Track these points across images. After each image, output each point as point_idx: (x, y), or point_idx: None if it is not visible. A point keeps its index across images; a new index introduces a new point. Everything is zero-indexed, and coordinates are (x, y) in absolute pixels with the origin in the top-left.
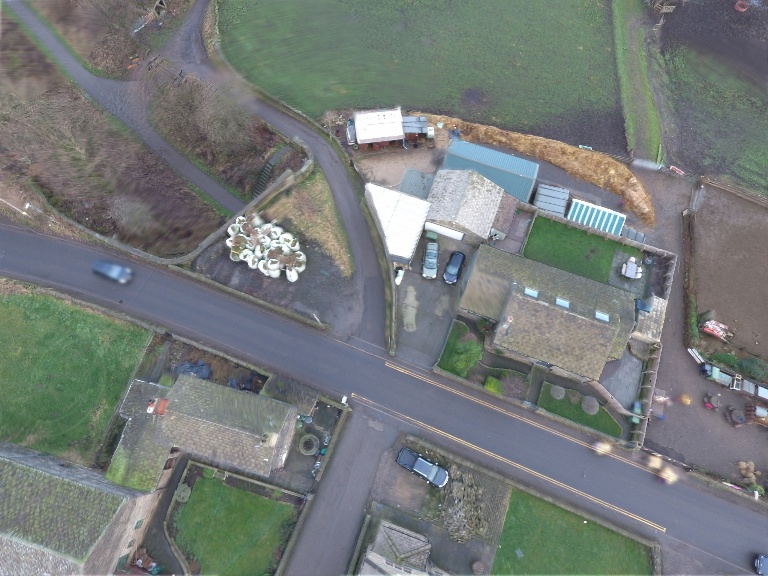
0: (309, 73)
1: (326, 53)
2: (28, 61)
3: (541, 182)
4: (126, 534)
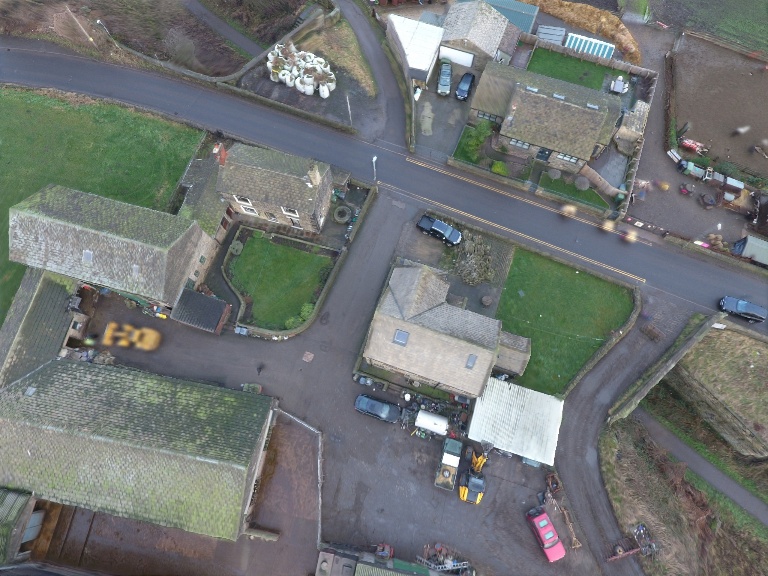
0: None
1: None
2: None
3: (541, 25)
4: (194, 259)
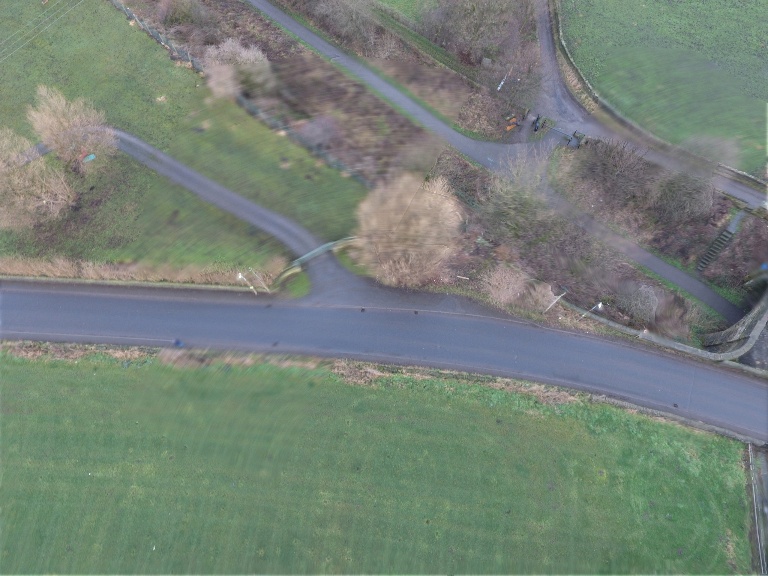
0: (707, 127)
1: (712, 105)
2: (397, 126)
3: None
4: None
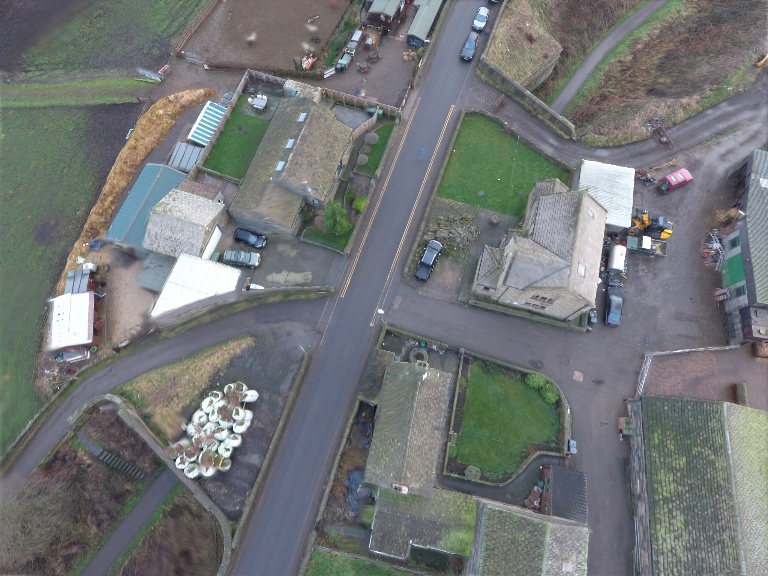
0: None
1: None
2: None
3: None
4: None
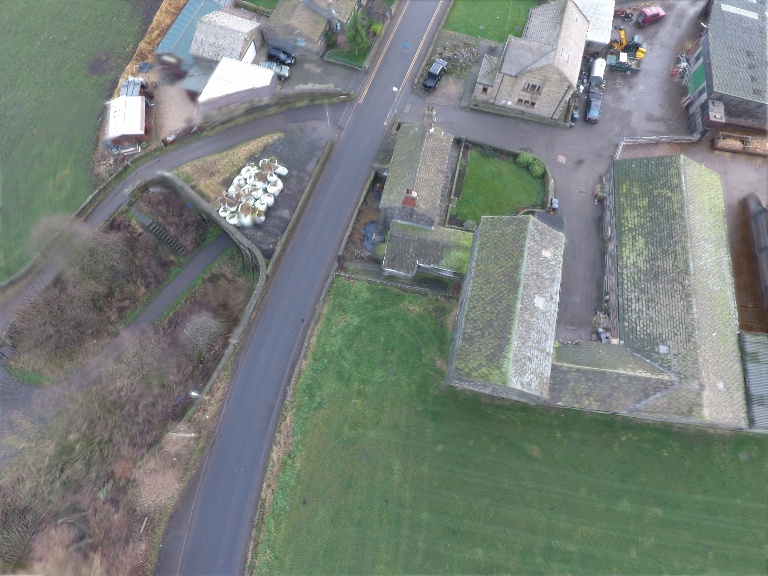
0: (31, 209)
1: (5, 196)
2: None
3: None
4: None
